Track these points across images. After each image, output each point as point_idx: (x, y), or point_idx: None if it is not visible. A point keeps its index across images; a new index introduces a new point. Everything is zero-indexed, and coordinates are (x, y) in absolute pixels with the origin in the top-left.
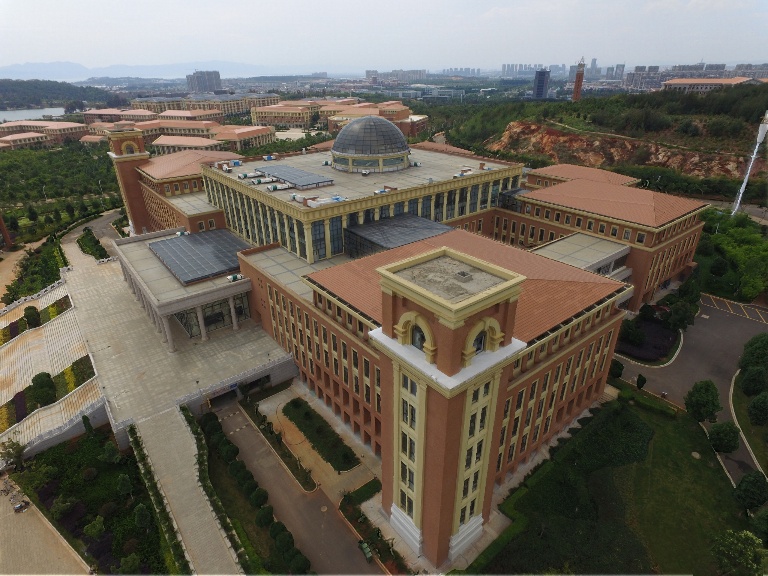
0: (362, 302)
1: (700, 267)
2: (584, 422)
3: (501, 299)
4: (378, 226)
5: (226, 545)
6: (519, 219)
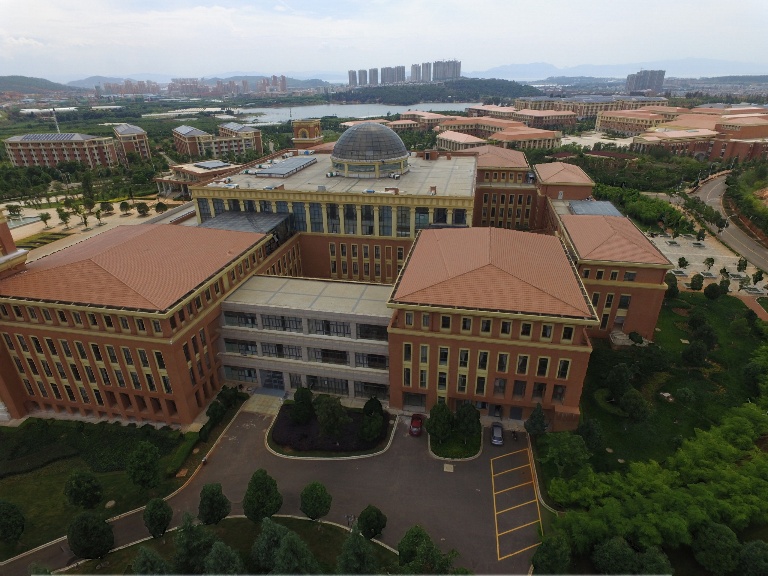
0: (75, 245)
1: (535, 410)
2: None
3: None
4: (242, 215)
5: None
6: None
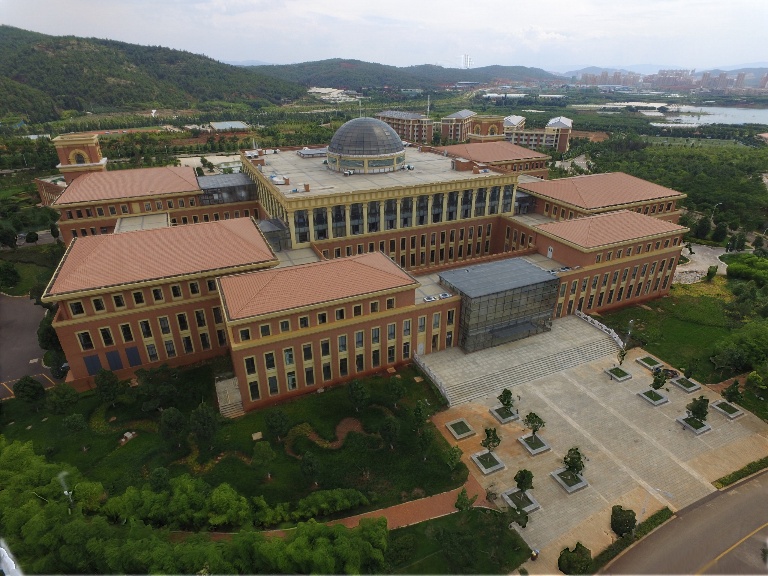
0: None
1: None
2: None
3: None
4: (237, 177)
5: None
6: None
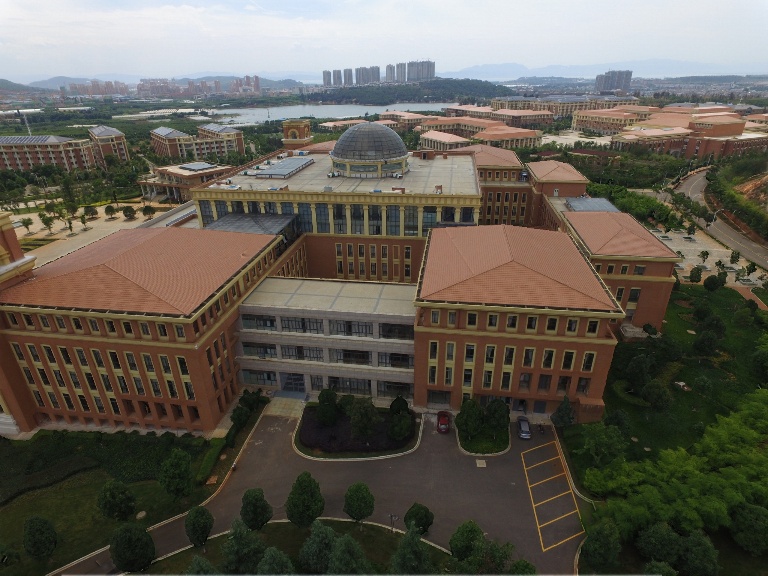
0: None
1: (563, 403)
2: (164, 435)
3: None
4: (247, 217)
5: None
6: None
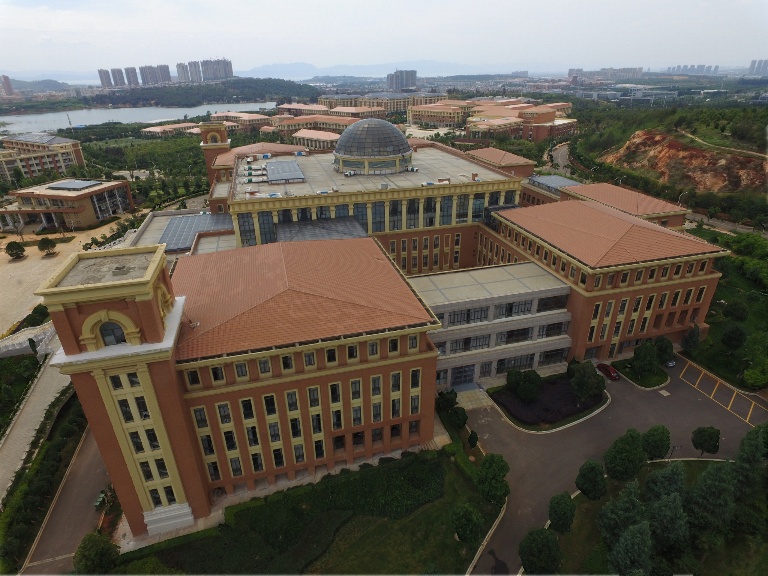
0: (175, 287)
1: (695, 330)
2: (383, 462)
3: (115, 295)
4: (305, 225)
5: (23, 457)
6: (494, 238)
